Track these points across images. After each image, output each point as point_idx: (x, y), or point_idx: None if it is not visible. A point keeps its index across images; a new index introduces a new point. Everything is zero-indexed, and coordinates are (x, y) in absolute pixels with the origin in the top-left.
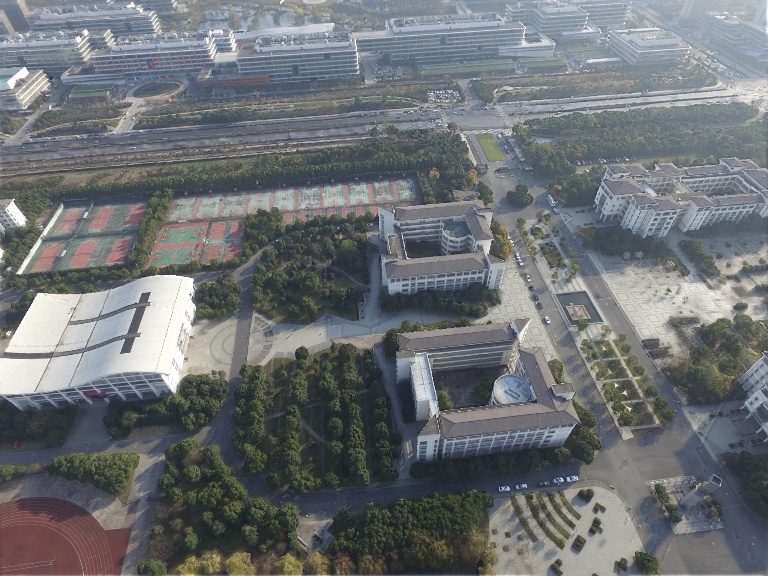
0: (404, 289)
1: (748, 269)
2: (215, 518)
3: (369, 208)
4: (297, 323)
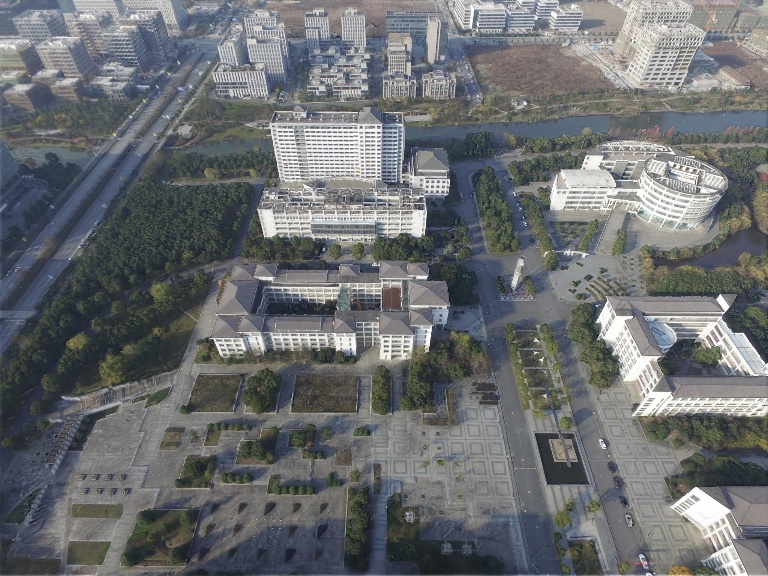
0: None
1: (311, 485)
2: None
3: None
4: None
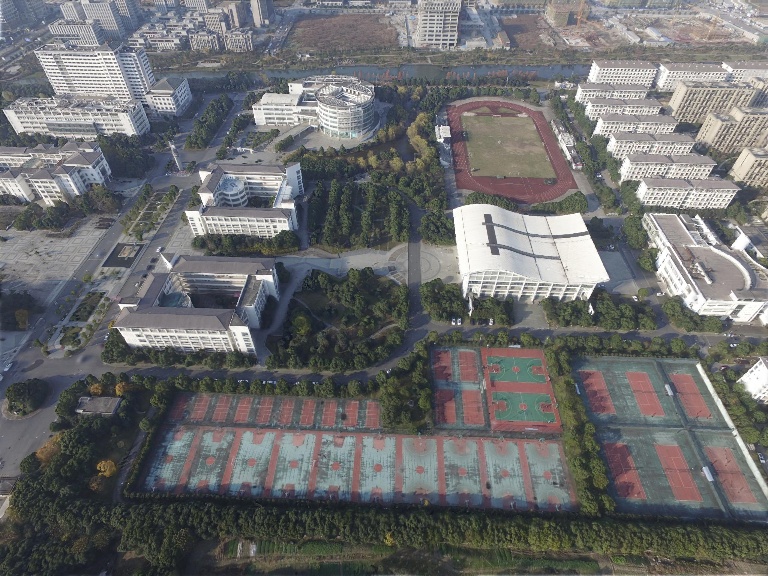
0: None
1: None
2: None
3: (249, 418)
4: None
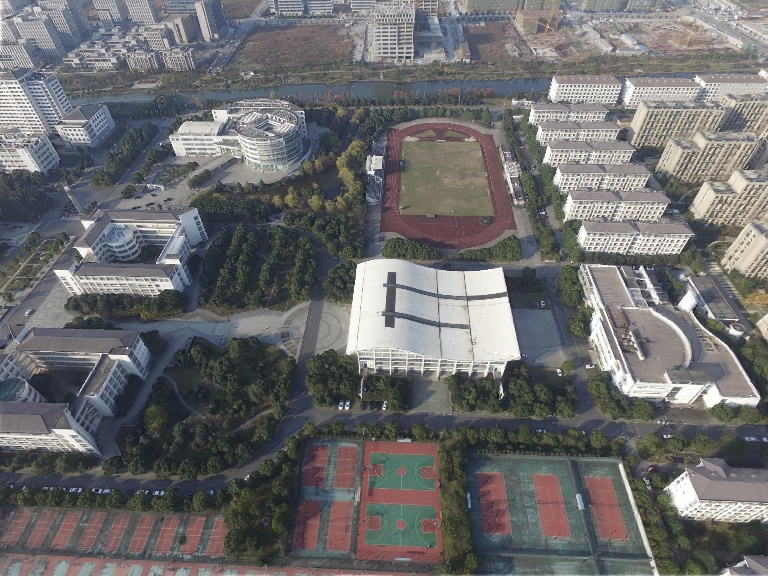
0: None
1: None
2: None
3: (70, 542)
4: None
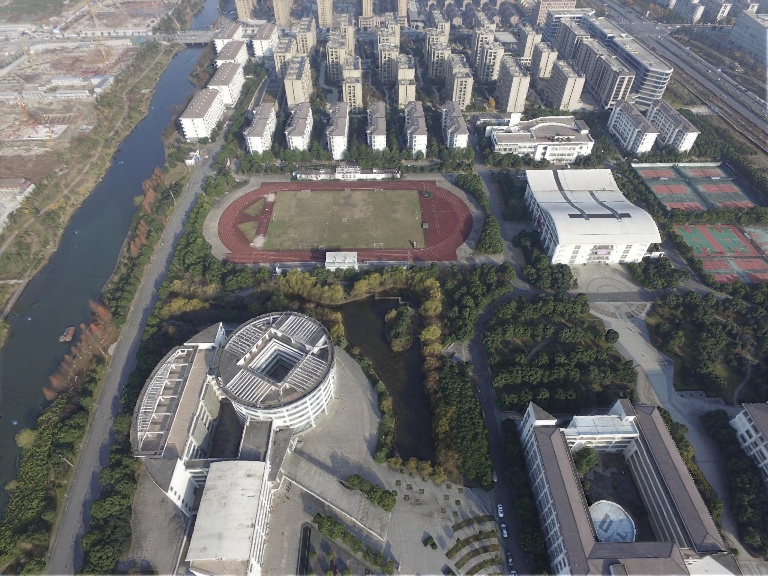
0: (744, 436)
1: None
2: (463, 294)
3: None
4: (651, 336)
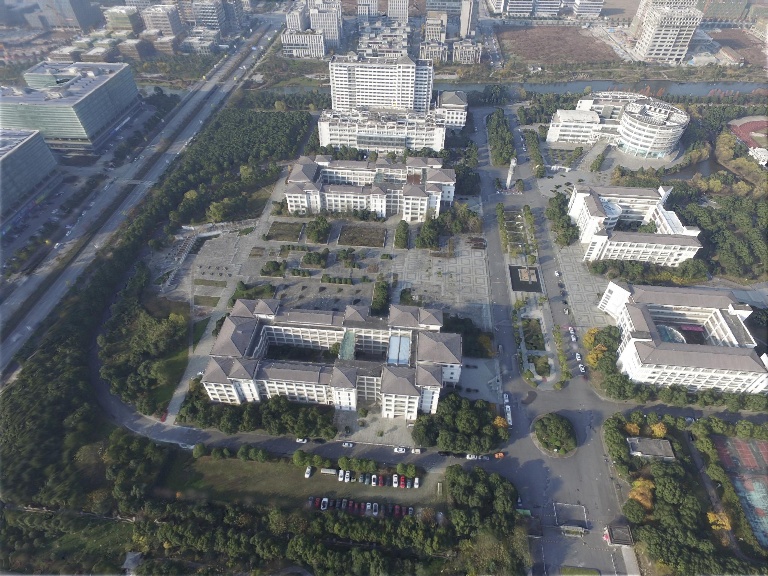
0: None
1: (350, 279)
2: None
3: None
4: None
